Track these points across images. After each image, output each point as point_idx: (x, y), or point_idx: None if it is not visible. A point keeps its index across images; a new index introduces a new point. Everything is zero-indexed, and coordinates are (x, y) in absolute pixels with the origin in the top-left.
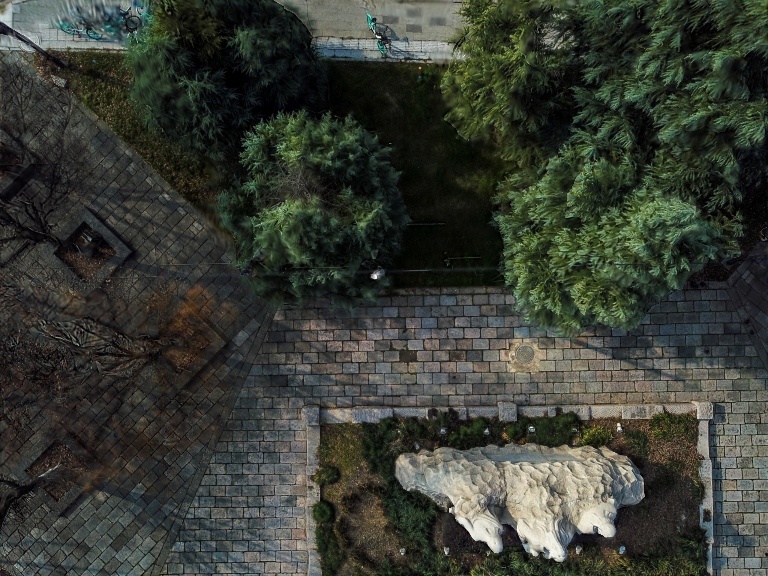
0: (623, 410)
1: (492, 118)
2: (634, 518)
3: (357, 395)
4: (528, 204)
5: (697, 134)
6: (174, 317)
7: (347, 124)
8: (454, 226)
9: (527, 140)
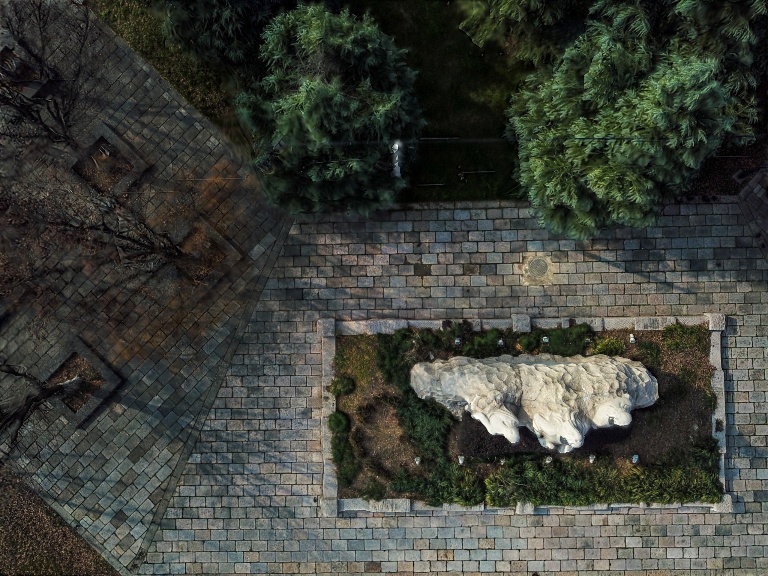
0: (636, 321)
1: (509, 9)
2: (647, 428)
3: (372, 308)
4: (544, 100)
5: (713, 9)
6: (191, 231)
7: (365, 22)
8: (468, 140)
9: (542, 39)
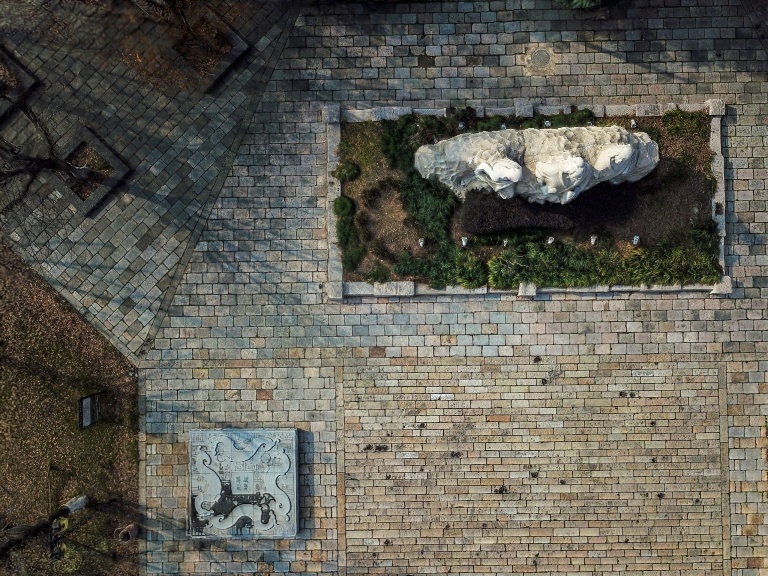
0: (637, 107)
1: None
2: (648, 211)
3: (376, 99)
4: None
5: None
6: (198, 22)
7: None
8: None
9: None
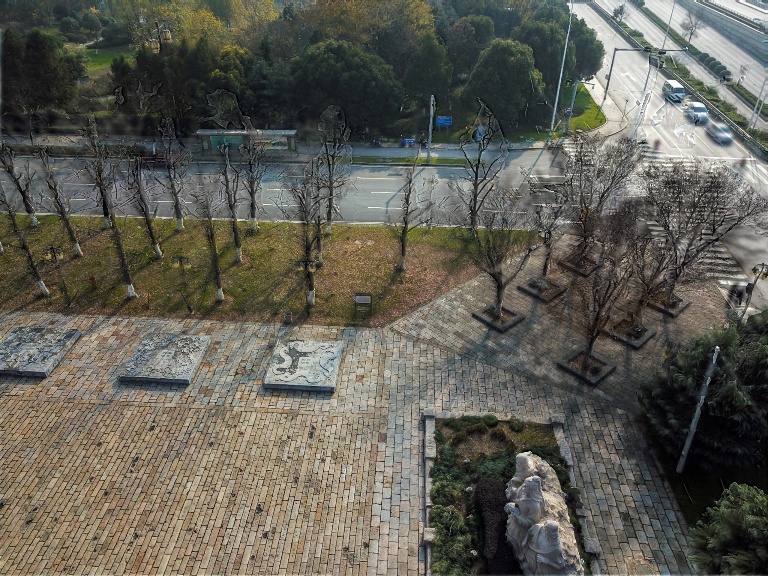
0: None
1: None
2: None
3: (576, 451)
4: None
5: None
6: (603, 362)
7: None
8: None
9: None
